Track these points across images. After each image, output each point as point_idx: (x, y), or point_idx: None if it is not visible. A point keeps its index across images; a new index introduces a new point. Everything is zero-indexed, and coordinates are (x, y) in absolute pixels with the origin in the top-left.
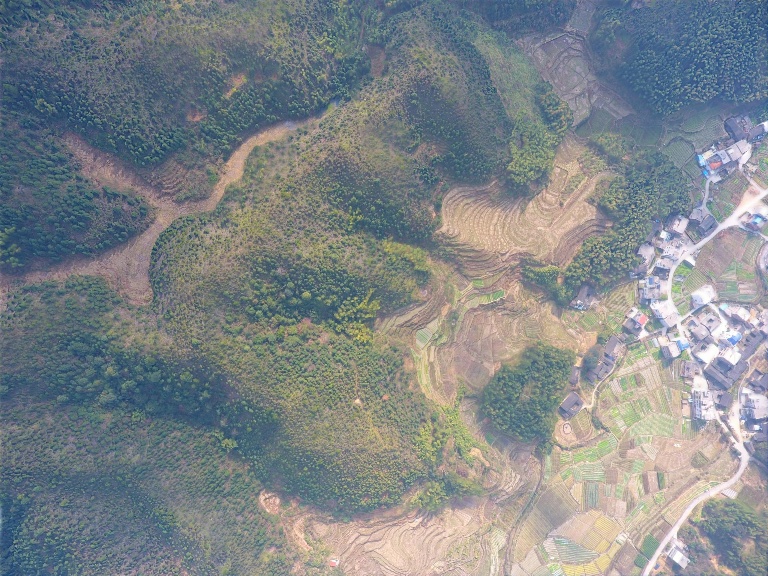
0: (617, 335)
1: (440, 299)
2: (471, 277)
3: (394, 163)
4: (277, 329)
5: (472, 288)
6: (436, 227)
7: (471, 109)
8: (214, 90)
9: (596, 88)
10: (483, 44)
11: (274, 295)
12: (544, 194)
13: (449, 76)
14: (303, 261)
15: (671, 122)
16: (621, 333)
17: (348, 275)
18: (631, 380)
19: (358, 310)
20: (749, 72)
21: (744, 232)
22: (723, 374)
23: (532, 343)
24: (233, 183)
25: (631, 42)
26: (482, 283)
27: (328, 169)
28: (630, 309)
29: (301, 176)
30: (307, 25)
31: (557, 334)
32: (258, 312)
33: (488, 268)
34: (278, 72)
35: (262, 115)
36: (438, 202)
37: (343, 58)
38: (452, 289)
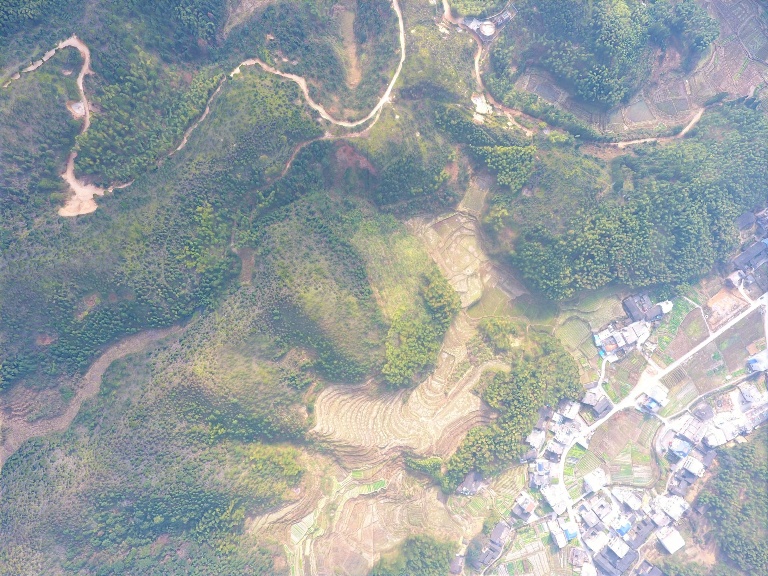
0: (506, 519)
1: (316, 494)
2: (350, 469)
3: (256, 377)
4: (128, 552)
5: (351, 479)
6: (309, 427)
7: (338, 320)
8: (63, 316)
9: (489, 267)
10: (363, 238)
11: (124, 521)
12: (429, 381)
13: (314, 290)
14: (151, 491)
15: (566, 302)
16: (510, 517)
17: (205, 494)
18: (518, 566)
19: (221, 520)
20: (642, 261)
21: (640, 413)
22: (612, 564)
23: (410, 538)
24: (88, 401)
25: (519, 232)
26: (361, 474)
27: (182, 392)
28: (519, 493)
29: (152, 402)
30: (166, 241)
31: (442, 520)
32: (104, 542)
33: (367, 461)
34: (132, 294)
35: (120, 330)
36: (309, 405)
37: (207, 269)
38: (330, 481)
